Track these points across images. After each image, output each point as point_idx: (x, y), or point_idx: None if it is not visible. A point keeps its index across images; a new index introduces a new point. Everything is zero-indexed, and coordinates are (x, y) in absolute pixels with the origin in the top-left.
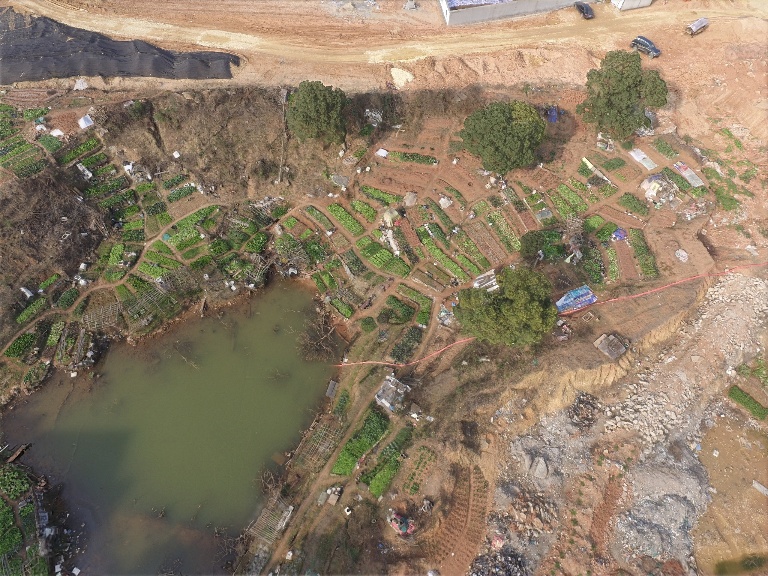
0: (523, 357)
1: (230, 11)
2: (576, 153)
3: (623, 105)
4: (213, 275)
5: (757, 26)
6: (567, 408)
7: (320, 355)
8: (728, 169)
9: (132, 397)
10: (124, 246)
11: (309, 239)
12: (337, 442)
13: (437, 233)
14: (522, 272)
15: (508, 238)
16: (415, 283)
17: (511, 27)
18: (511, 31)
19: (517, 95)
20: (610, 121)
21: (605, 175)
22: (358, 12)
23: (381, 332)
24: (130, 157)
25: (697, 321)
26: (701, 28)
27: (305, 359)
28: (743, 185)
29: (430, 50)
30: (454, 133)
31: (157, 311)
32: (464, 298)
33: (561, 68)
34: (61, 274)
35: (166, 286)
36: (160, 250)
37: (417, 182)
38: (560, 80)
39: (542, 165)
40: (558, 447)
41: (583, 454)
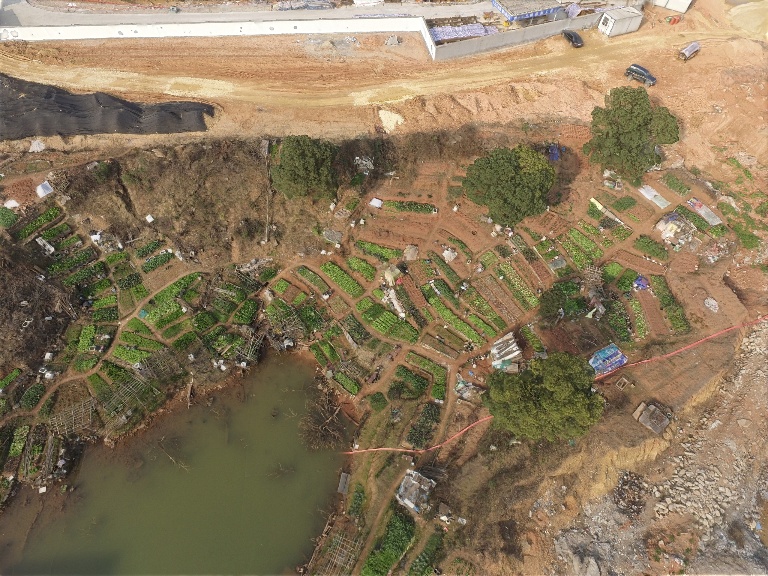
0: (557, 436)
1: (200, 55)
2: (583, 193)
3: (634, 144)
4: (199, 354)
5: (748, 48)
6: (611, 492)
7: (327, 442)
8: (742, 202)
9: (113, 512)
10: (95, 328)
11: (304, 304)
12: (357, 554)
13: (444, 291)
14: (561, 358)
15: (522, 293)
16: (425, 350)
17: (500, 59)
18: (500, 64)
19: (515, 133)
20: (621, 161)
21: (617, 216)
22: (338, 50)
23: (393, 410)
24: (97, 225)
25: (736, 377)
26: (694, 53)
27: (310, 448)
28: (760, 219)
29: (418, 88)
30: (452, 178)
31: (137, 404)
32: (497, 390)
33: (557, 102)
34: (23, 368)
35: (146, 374)
36: (137, 330)
37: (417, 233)
38: (557, 115)
39: (549, 208)
40: (607, 541)
41: (636, 548)
